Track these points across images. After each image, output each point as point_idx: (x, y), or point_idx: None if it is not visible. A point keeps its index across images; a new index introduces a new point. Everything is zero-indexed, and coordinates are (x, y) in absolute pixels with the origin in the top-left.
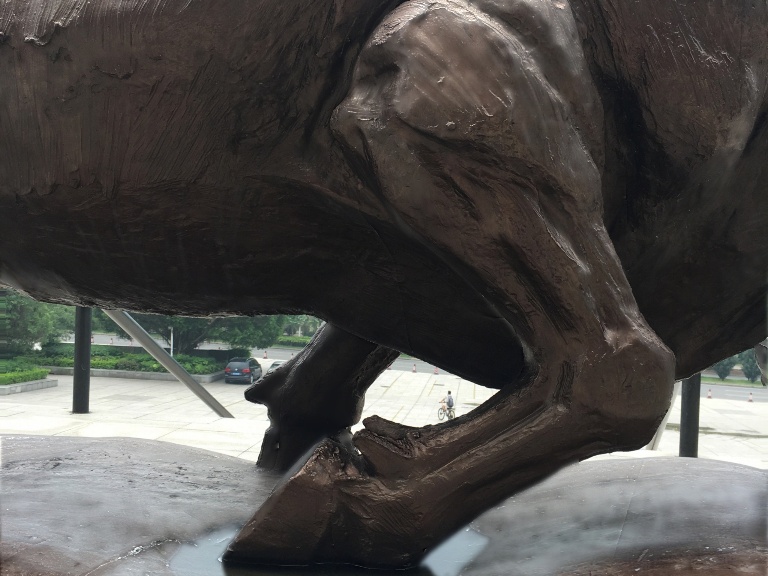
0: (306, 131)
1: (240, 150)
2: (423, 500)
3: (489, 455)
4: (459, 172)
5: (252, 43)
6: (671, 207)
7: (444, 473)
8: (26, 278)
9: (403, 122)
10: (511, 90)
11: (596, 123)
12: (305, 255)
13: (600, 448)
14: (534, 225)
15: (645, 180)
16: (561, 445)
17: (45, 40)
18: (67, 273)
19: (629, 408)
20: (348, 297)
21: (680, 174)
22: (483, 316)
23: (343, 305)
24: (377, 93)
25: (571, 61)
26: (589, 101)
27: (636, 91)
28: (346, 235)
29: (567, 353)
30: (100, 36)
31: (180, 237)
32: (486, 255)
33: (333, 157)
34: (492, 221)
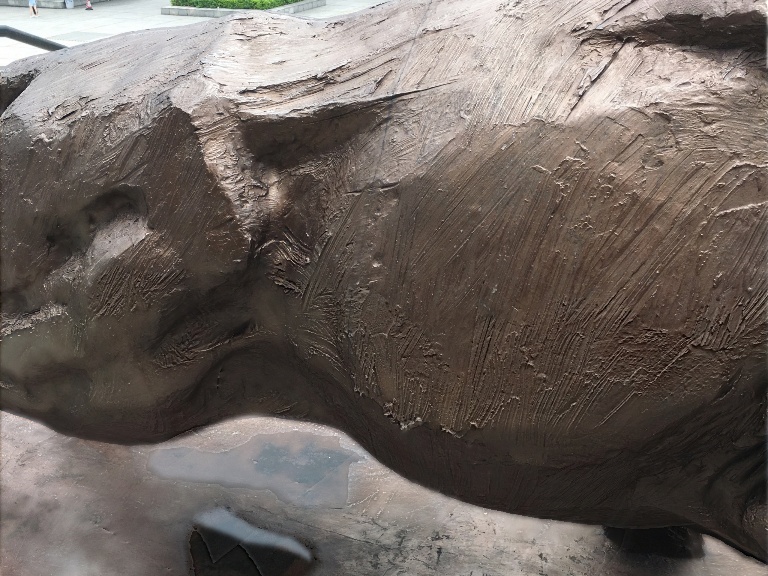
0: (709, 482)
1: (638, 485)
2: None
3: None
4: None
5: (665, 438)
6: None
7: None
8: None
9: None
10: None
11: None
12: (688, 525)
13: None
14: None
15: None
16: None
17: (461, 434)
18: None
19: None
20: None
21: None
22: None
23: None
24: None
25: None
26: None
27: None
28: None
29: None
30: (514, 437)
31: None
32: None
33: (735, 506)
34: None
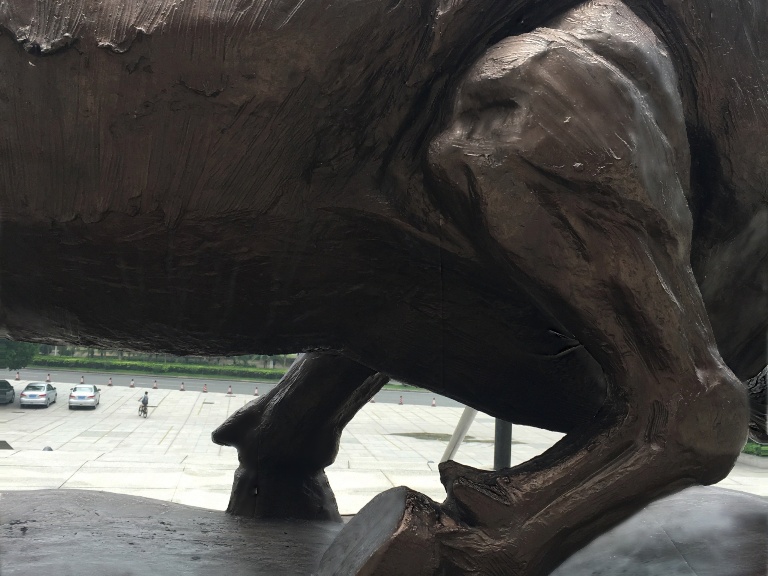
0: (384, 162)
1: (313, 179)
2: (527, 548)
3: (586, 497)
4: (575, 213)
5: (345, 66)
6: (723, 249)
7: (542, 518)
8: (21, 315)
9: (525, 160)
10: (634, 134)
11: (688, 169)
12: (356, 291)
13: (685, 484)
14: (645, 268)
15: (707, 223)
16: (654, 483)
17: (124, 47)
18: (84, 310)
19: (719, 445)
20: (385, 334)
21: (744, 219)
22: (528, 353)
23: (378, 343)
24: (483, 128)
25: (676, 108)
26: (686, 147)
27: (715, 139)
28: (402, 271)
29: (659, 392)
30: (189, 47)
31: (235, 272)
32: (591, 296)
33: (411, 190)
34: (604, 263)
